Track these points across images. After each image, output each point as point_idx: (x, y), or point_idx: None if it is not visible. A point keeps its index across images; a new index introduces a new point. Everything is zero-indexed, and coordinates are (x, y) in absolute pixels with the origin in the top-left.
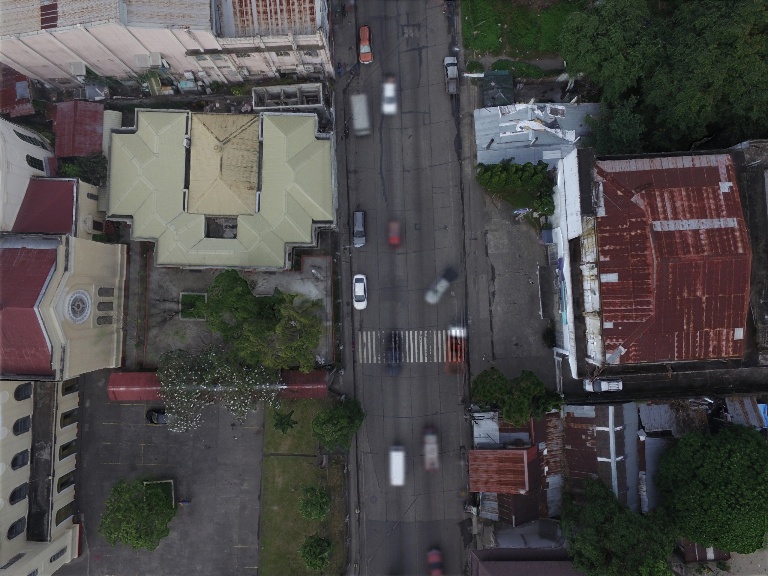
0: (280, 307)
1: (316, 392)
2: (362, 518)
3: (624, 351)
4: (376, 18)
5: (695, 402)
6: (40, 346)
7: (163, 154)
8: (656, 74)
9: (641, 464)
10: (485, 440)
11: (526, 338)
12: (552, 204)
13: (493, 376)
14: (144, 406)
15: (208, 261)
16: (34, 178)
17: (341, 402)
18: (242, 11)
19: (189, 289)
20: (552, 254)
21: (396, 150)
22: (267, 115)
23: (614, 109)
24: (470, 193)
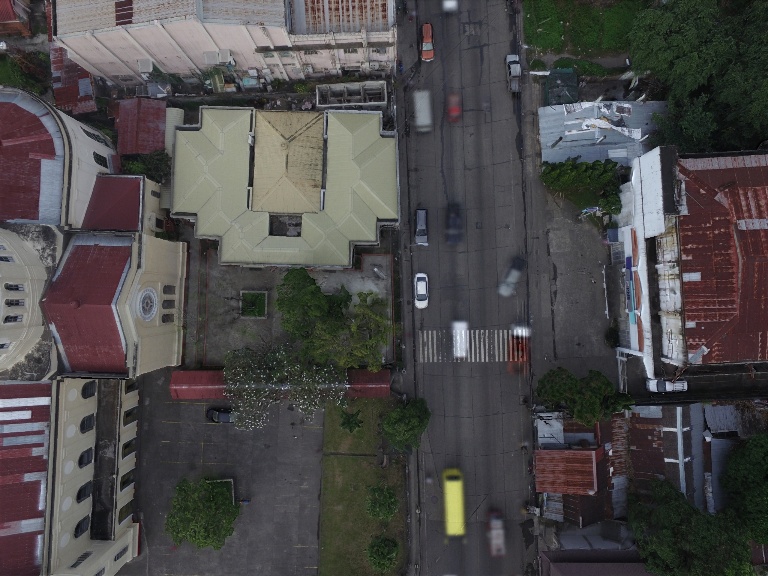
0: None
1: (379, 391)
2: (423, 518)
3: (707, 351)
4: (437, 16)
5: (761, 403)
6: (114, 344)
7: (228, 151)
8: (729, 72)
9: (707, 465)
10: (549, 440)
11: (588, 338)
12: (619, 203)
13: (562, 376)
14: (204, 405)
15: (272, 259)
16: (100, 175)
17: (403, 401)
18: (314, 8)
19: (249, 287)
20: (616, 253)
21: (457, 148)
22: (332, 113)
23: (683, 107)
24: (532, 192)
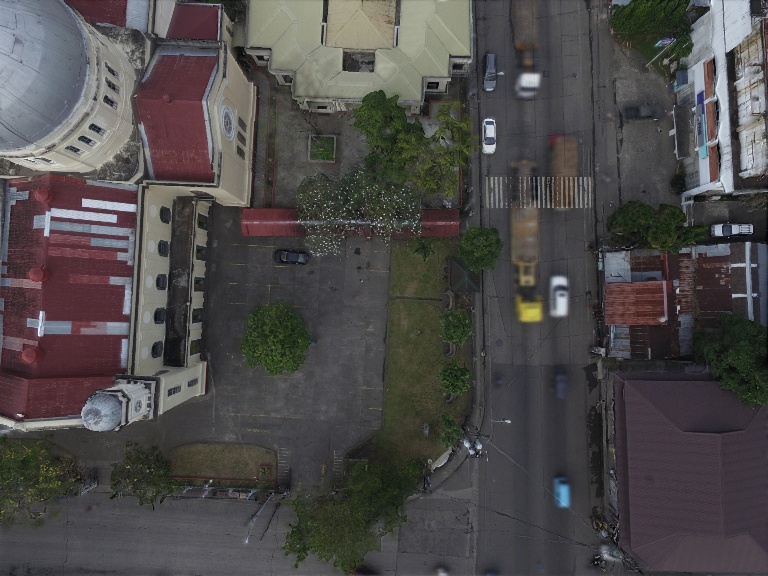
0: None
1: (448, 229)
2: (487, 361)
3: None
4: None
5: None
6: (201, 148)
7: None
8: None
9: None
10: (616, 280)
11: (653, 185)
12: (690, 42)
13: (634, 205)
14: (271, 247)
15: (346, 94)
16: (179, 3)
17: None
18: None
19: None
20: (684, 98)
21: None
22: None
23: None
24: (599, 41)
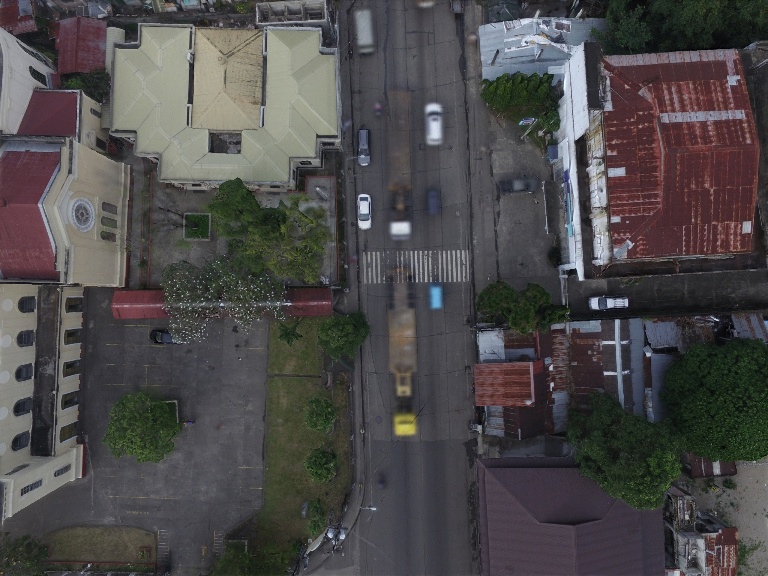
0: (285, 209)
1: (321, 309)
2: (367, 438)
3: (631, 245)
4: None
5: (701, 319)
6: (44, 247)
7: (167, 68)
8: None
9: (647, 380)
10: (490, 357)
11: (531, 258)
12: (558, 118)
13: (499, 287)
14: (148, 327)
15: (212, 176)
16: (37, 90)
17: None
18: None
19: (193, 210)
20: (557, 171)
21: (400, 70)
22: (271, 30)
23: (620, 20)
24: (475, 113)
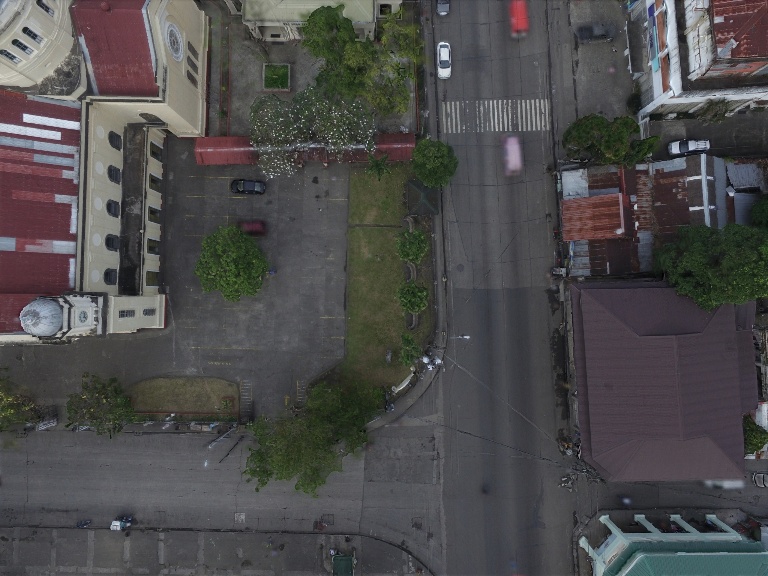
0: None
1: (404, 152)
2: (449, 286)
3: (736, 44)
4: None
5: None
6: (144, 61)
7: None
8: None
9: (730, 220)
10: None
11: (610, 106)
12: None
13: (588, 118)
14: (228, 179)
15: (297, 16)
16: None
17: None
18: None
19: (271, 62)
20: (637, 16)
21: None
22: None
23: None
24: None
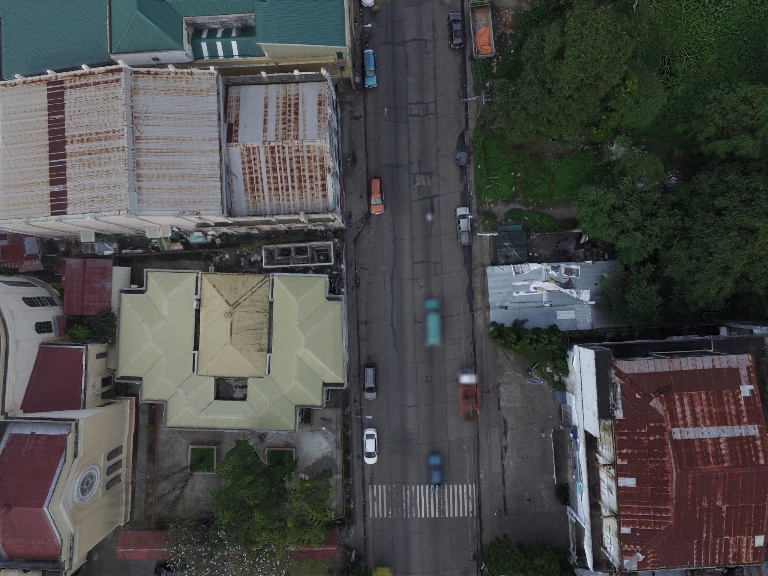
0: (291, 497)
1: (326, 553)
2: None
3: (642, 558)
4: (387, 166)
5: None
6: (49, 538)
7: (173, 317)
8: (674, 249)
9: None
10: None
11: (539, 493)
12: (566, 368)
13: (506, 550)
14: None
15: (218, 424)
16: (43, 346)
17: (351, 562)
18: (253, 188)
19: (198, 441)
20: (566, 412)
21: (407, 301)
22: (277, 276)
23: (630, 276)
24: (482, 345)
